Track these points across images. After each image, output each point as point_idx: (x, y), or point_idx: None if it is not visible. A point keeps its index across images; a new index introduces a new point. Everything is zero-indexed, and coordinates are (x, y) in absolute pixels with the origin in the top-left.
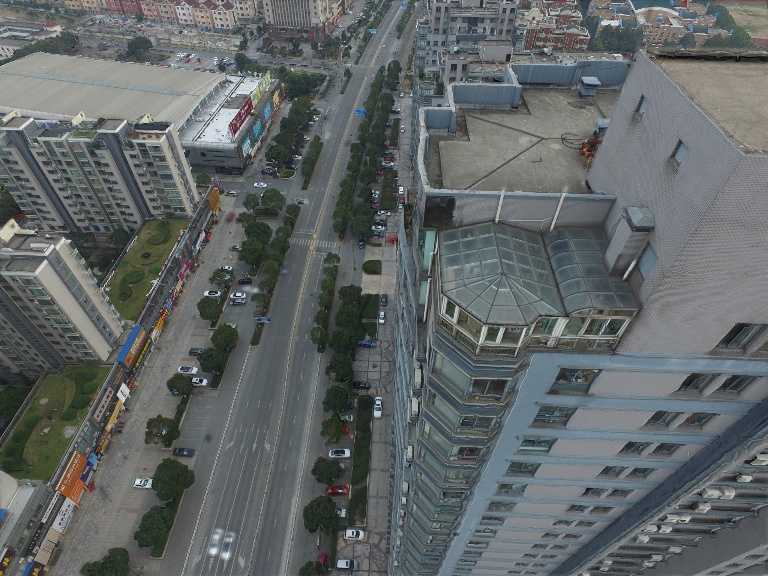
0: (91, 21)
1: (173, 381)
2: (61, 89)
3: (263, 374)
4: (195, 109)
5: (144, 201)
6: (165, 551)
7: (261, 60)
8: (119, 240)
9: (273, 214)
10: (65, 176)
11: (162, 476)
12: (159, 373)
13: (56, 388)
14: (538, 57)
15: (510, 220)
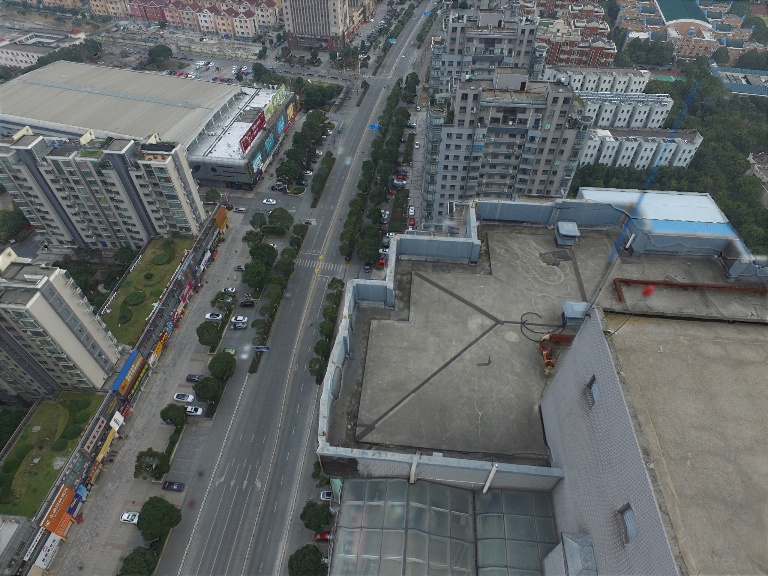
0: (115, 27)
1: (166, 411)
2: (78, 100)
3: (259, 405)
4: (208, 123)
5: (150, 220)
6: None
7: (279, 70)
8: (124, 259)
9: (280, 233)
10: (73, 194)
11: (147, 516)
12: (155, 399)
13: (49, 415)
14: (554, 87)
15: (431, 478)
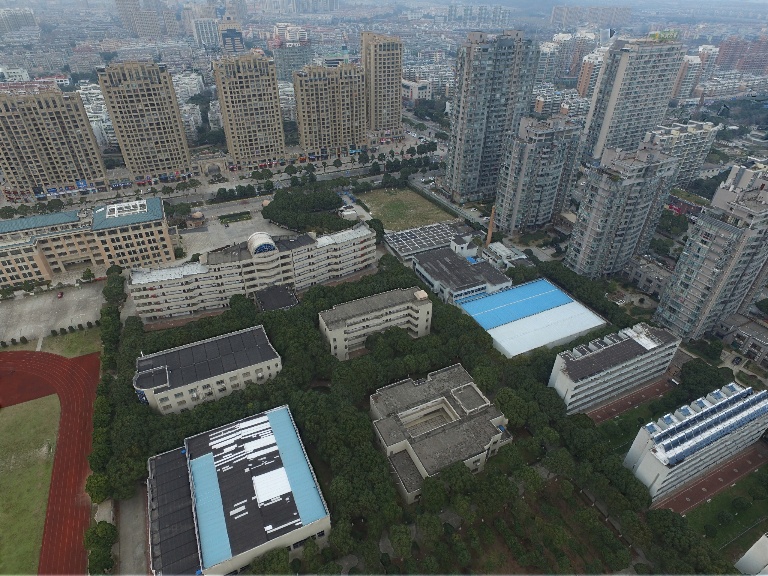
0: None
1: None
2: None
3: None
4: None
5: None
6: None
7: None
8: None
9: None
10: None
11: None
12: None
13: None
14: None
15: None
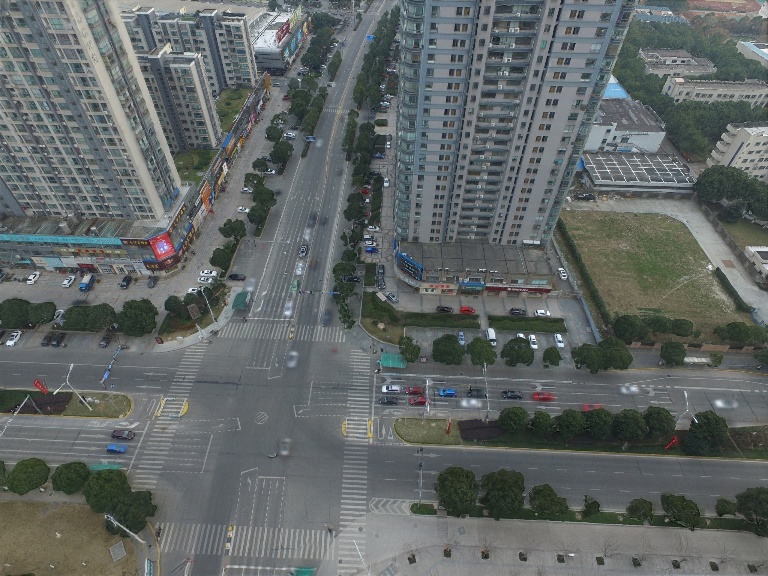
0: None
1: (257, 162)
2: None
3: (311, 170)
4: None
5: (223, 73)
6: (262, 235)
7: None
8: None
9: None
10: None
11: (260, 191)
12: (243, 168)
13: (186, 158)
14: None
15: None
